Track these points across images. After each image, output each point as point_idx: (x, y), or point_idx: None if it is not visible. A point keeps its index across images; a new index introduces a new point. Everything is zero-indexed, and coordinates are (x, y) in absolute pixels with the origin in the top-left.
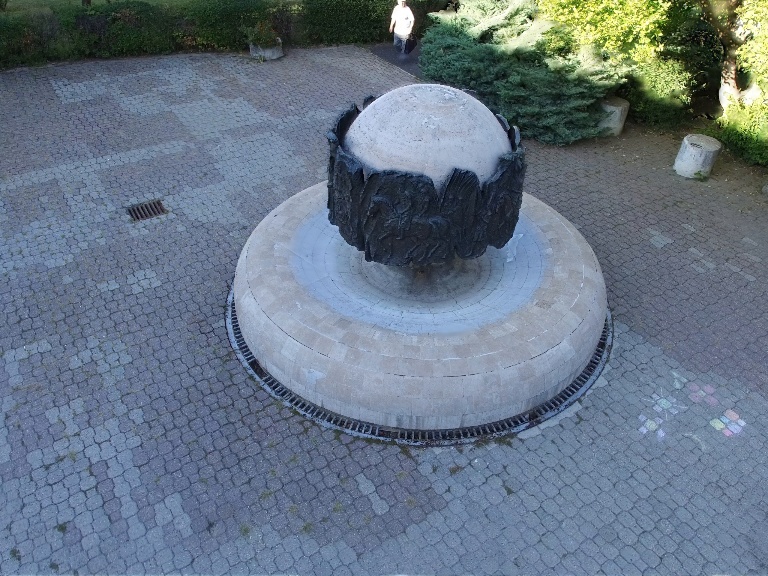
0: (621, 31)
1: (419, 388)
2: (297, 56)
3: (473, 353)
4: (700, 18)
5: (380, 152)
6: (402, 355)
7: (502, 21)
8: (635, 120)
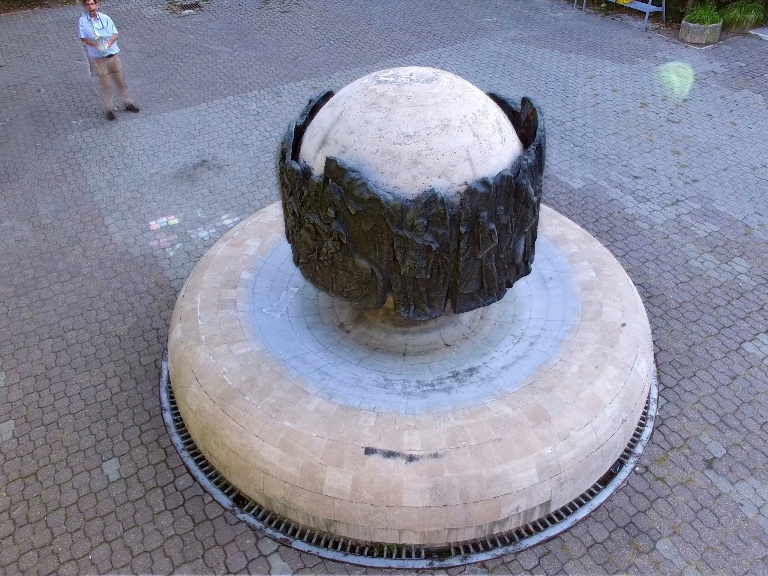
0: None
1: None
2: None
3: None
4: None
5: None
6: None
7: None
8: None
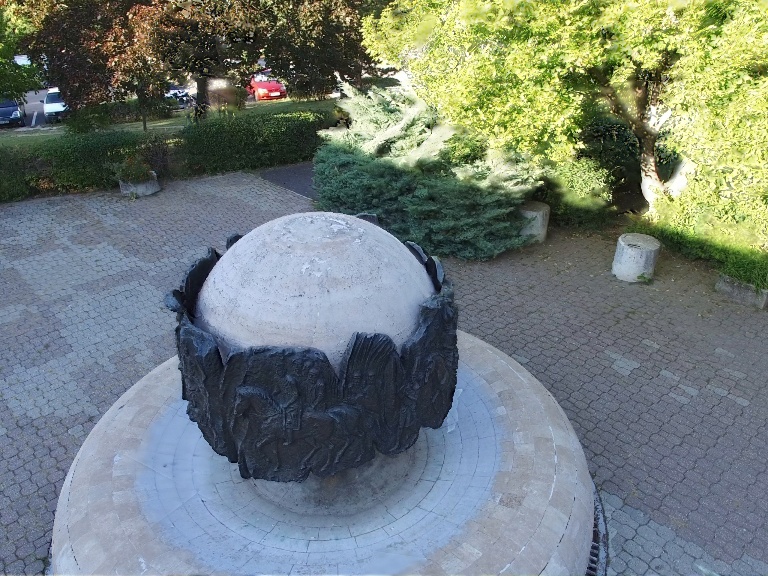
0: (534, 130)
1: None
2: (176, 189)
3: None
4: (609, 112)
5: (244, 318)
6: None
7: (398, 133)
8: (557, 223)
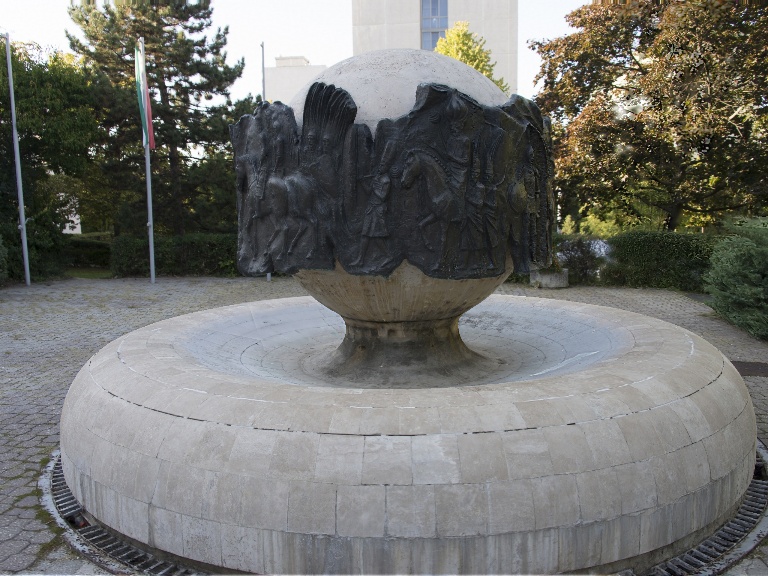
0: None
1: (114, 419)
2: (582, 289)
3: (234, 392)
4: None
5: None
6: (147, 372)
7: None
8: None
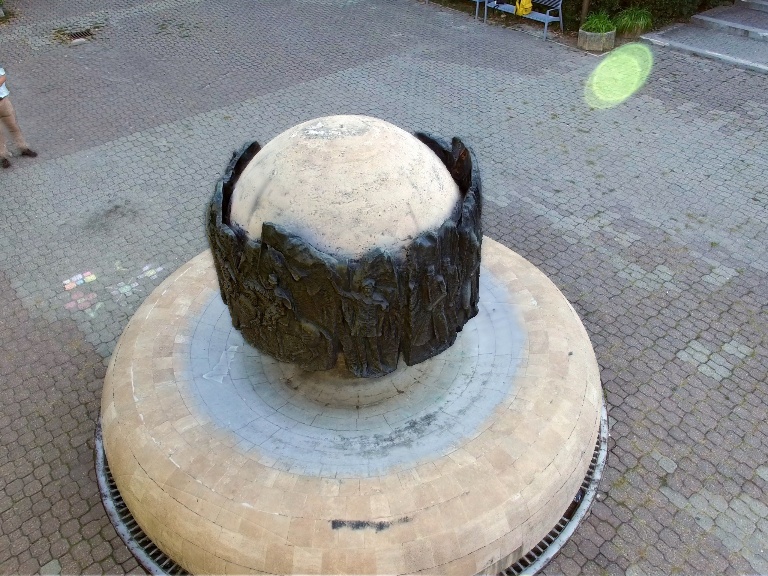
0: None
1: None
2: None
3: None
4: None
5: None
6: None
7: None
8: None
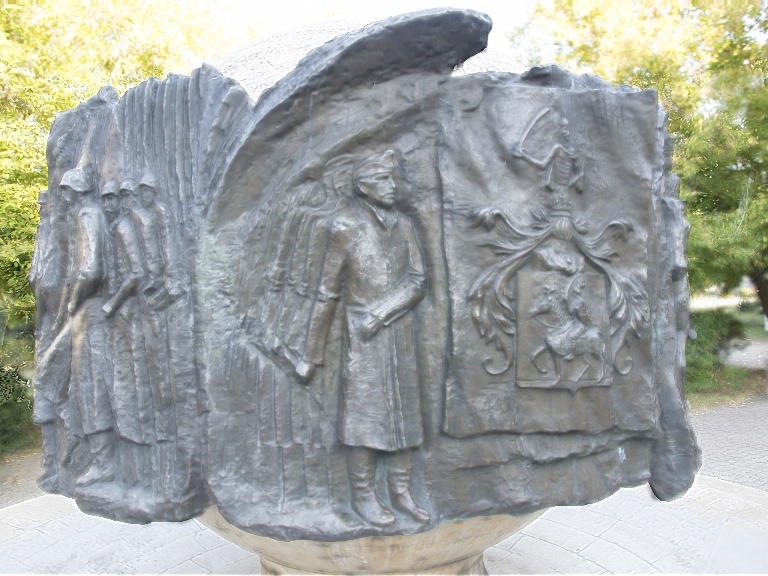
0: None
1: None
2: None
3: None
4: None
5: None
6: None
7: None
8: None
